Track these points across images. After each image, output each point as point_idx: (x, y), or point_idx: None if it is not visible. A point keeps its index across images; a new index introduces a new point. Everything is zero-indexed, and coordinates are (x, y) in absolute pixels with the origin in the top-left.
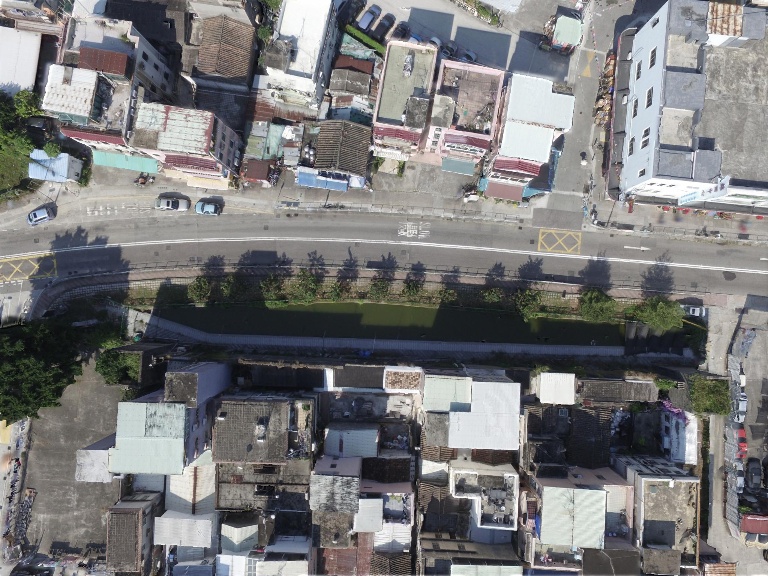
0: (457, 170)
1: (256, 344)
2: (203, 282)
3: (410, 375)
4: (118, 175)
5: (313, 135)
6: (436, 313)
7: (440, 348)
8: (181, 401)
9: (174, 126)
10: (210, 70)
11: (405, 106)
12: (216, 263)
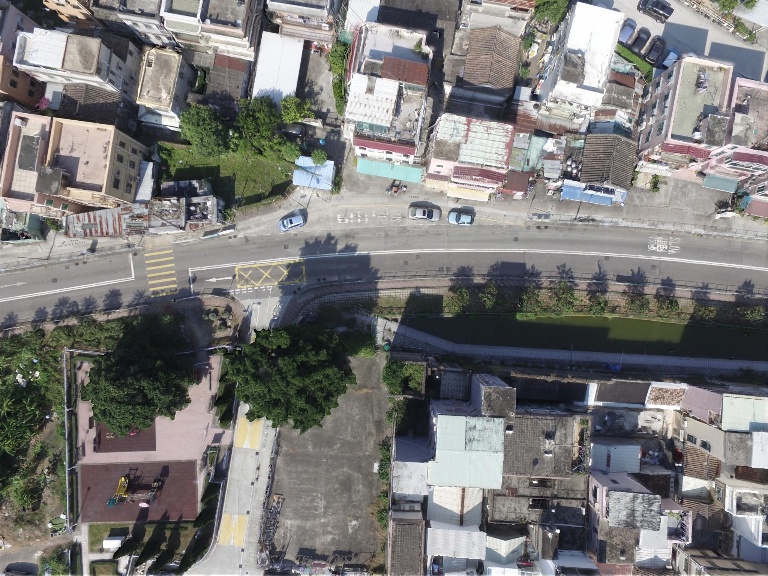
0: (719, 187)
1: (503, 355)
2: (465, 293)
3: (674, 391)
4: (369, 183)
5: (574, 148)
6: (683, 329)
7: (688, 364)
8: (499, 415)
9: (475, 138)
10: (481, 81)
11: (696, 123)
12: (465, 273)
